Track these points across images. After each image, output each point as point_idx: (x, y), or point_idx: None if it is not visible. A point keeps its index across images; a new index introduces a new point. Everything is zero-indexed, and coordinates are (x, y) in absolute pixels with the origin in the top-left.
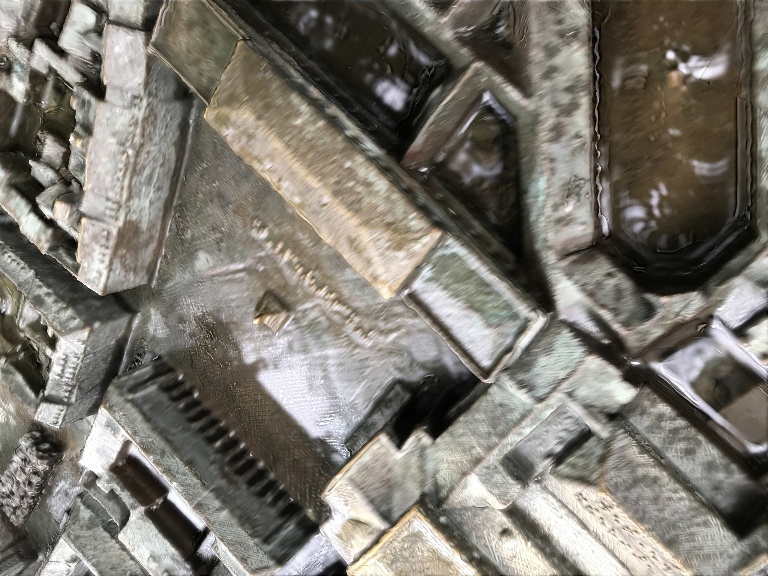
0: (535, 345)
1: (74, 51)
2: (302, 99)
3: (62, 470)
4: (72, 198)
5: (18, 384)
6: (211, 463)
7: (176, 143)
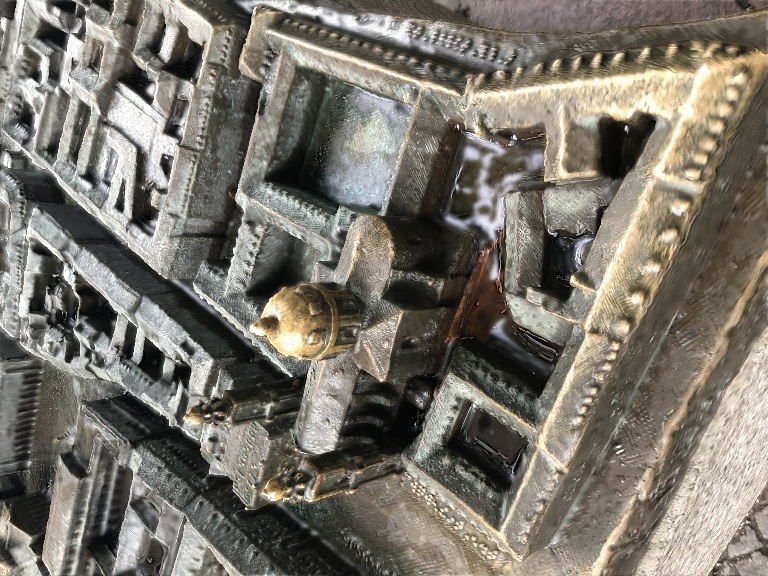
0: None
1: None
2: (71, 515)
3: None
4: (40, 334)
5: None
6: (9, 421)
7: None
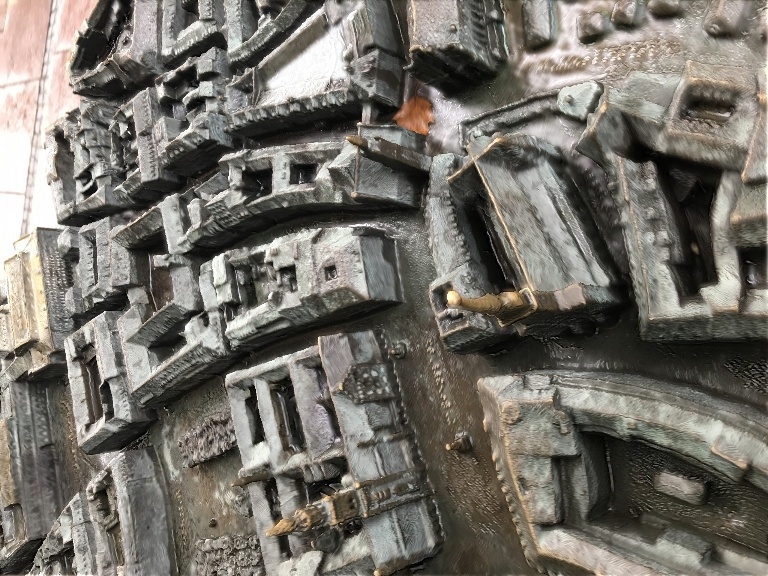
0: None
1: None
2: None
3: None
4: None
5: None
6: None
7: None
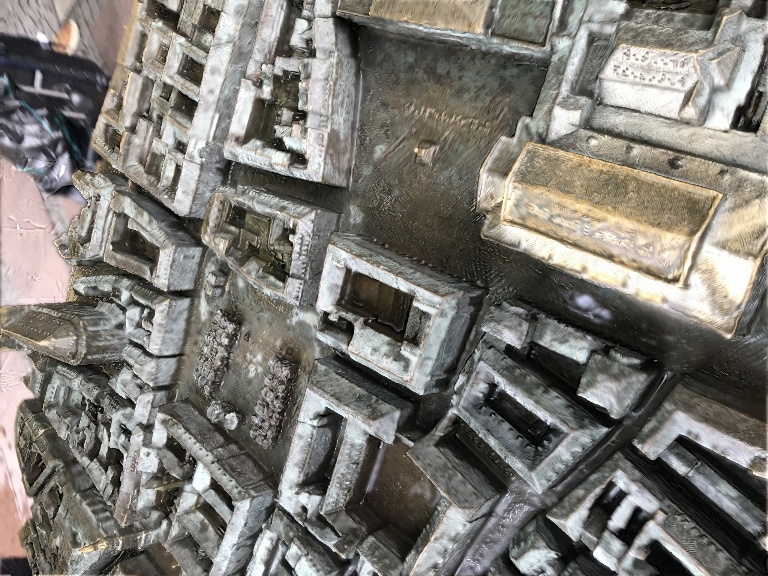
0: (565, 16)
1: (298, 45)
2: None
3: (298, 386)
4: None
5: (271, 282)
6: (404, 260)
7: (354, 85)
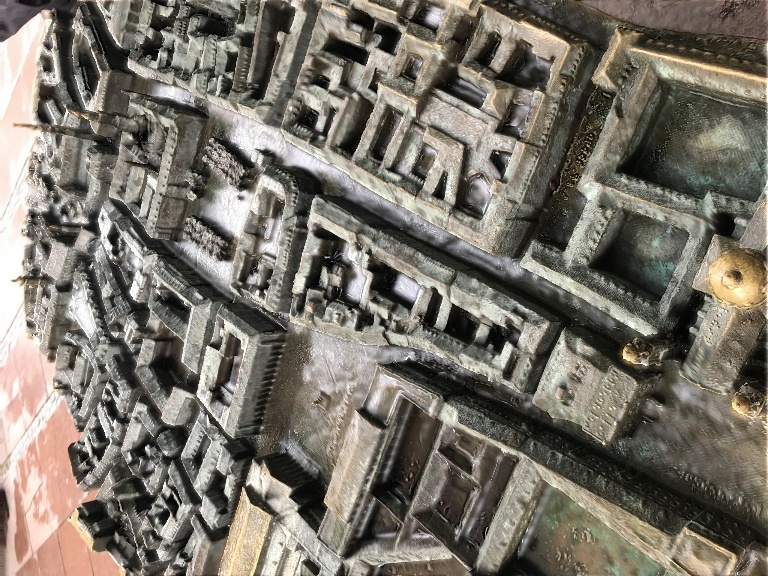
0: None
1: (370, 308)
2: (369, 462)
3: None
4: (318, 307)
5: (239, 266)
6: (255, 389)
7: None
